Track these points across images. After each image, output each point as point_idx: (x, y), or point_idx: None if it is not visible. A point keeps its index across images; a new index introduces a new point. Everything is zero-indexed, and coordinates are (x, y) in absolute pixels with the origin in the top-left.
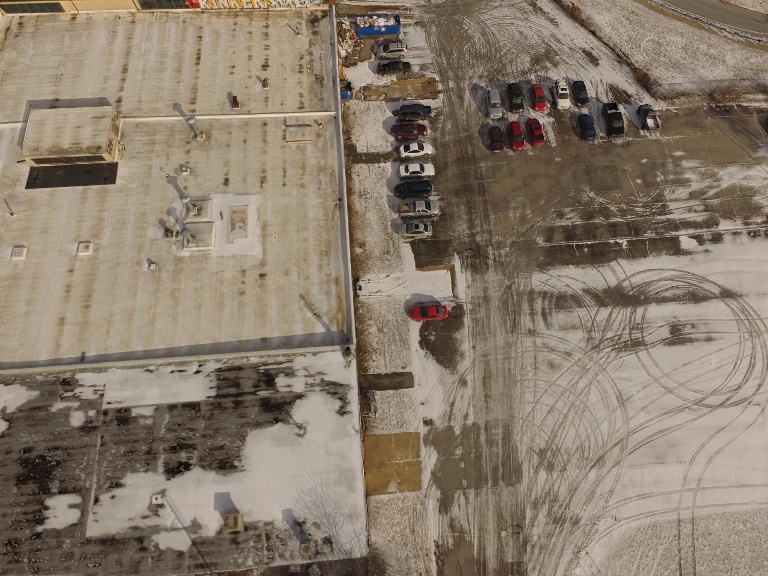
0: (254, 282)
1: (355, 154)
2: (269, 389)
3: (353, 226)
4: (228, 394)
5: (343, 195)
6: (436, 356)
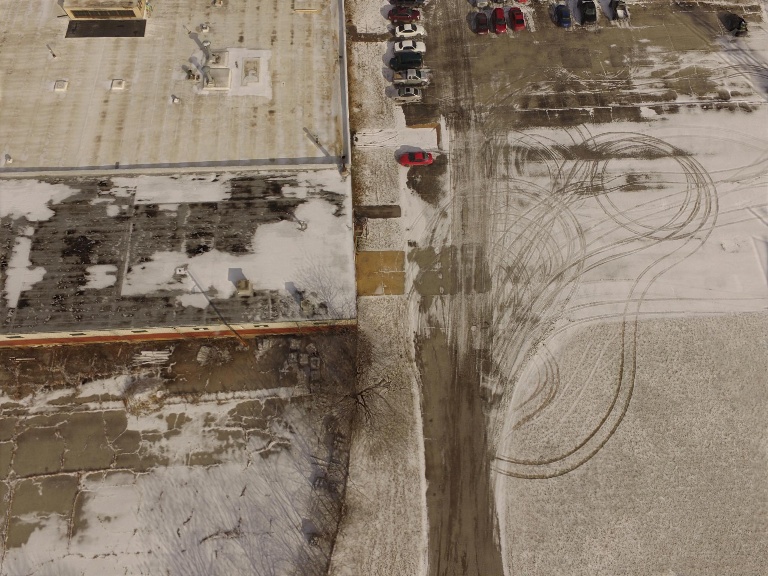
0: (264, 117)
1: (355, 34)
2: (276, 195)
3: (352, 90)
4: (241, 197)
5: (343, 53)
6: (421, 194)
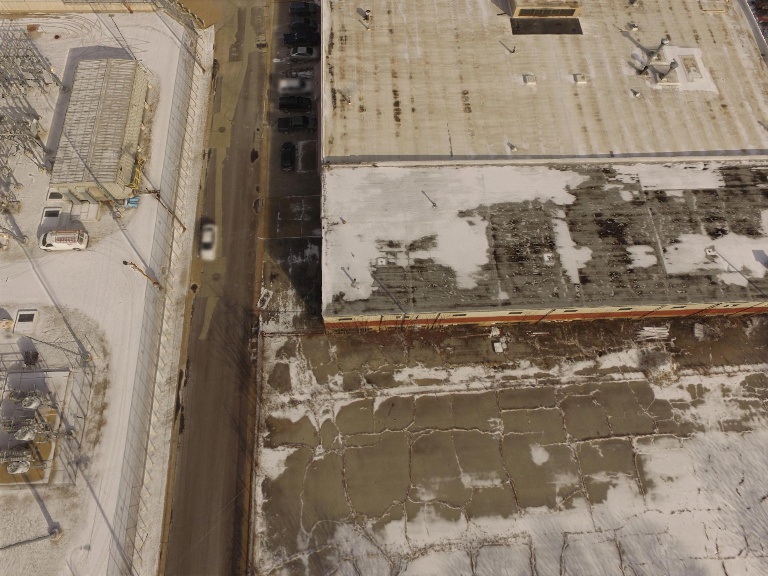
0: (719, 110)
1: None
2: (765, 183)
3: None
4: (735, 185)
5: (766, 51)
6: None
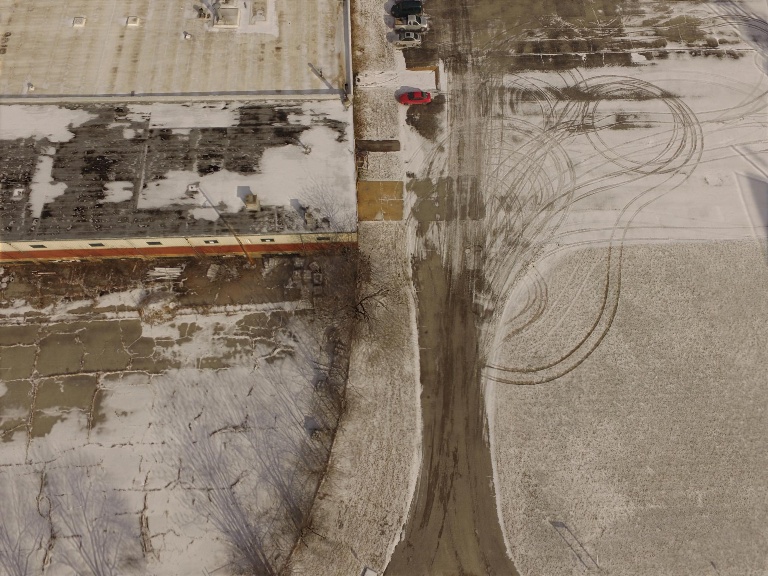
0: (271, 52)
1: None
2: (282, 122)
3: (354, 35)
4: (249, 124)
5: None
6: (420, 130)
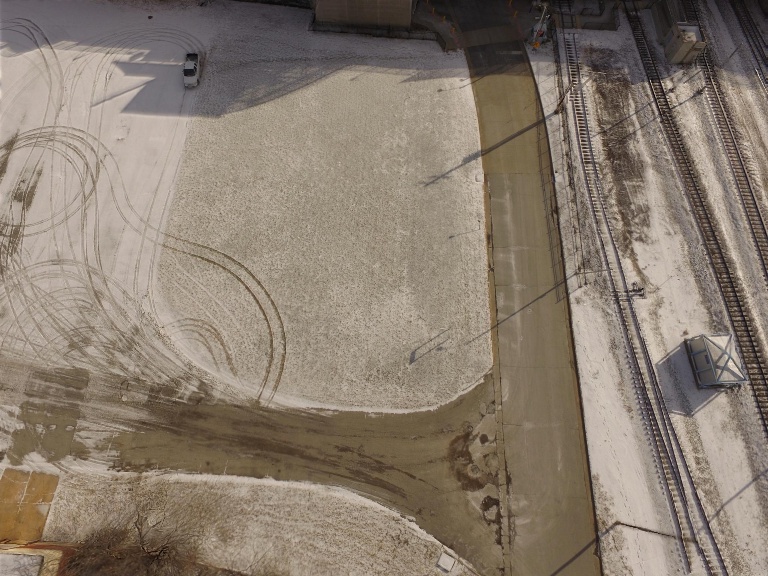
0: None
1: None
2: None
3: None
4: None
5: None
6: None
